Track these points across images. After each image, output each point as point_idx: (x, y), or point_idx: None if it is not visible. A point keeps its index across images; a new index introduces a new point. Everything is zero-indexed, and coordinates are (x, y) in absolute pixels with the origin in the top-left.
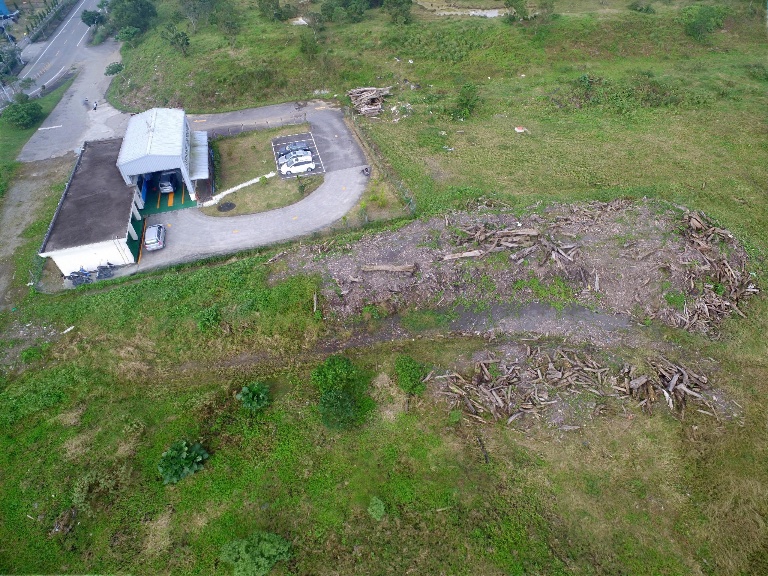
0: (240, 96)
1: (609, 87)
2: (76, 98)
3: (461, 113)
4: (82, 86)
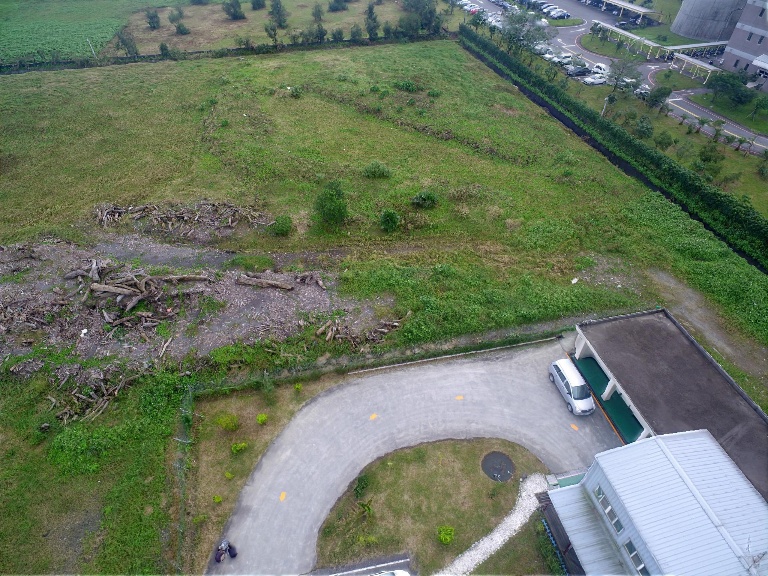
0: None
1: None
2: None
3: None
4: None
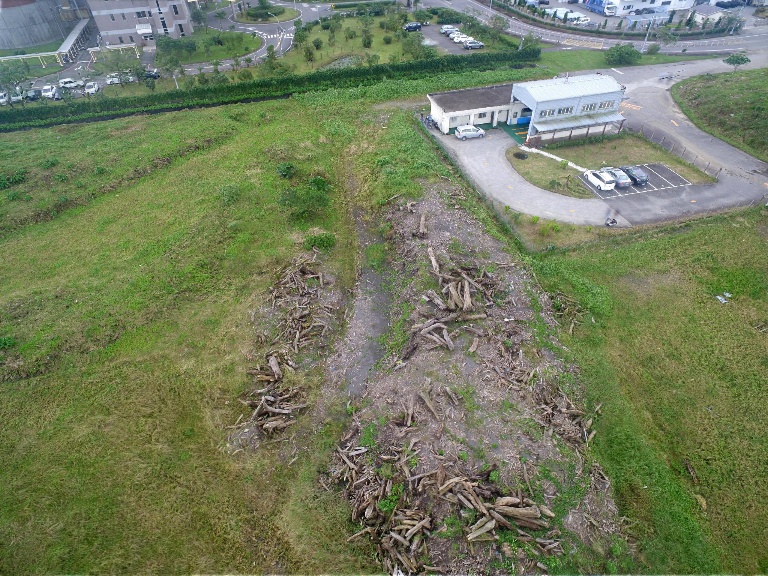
0: (743, 129)
1: None
2: (679, 67)
3: None
4: (707, 63)
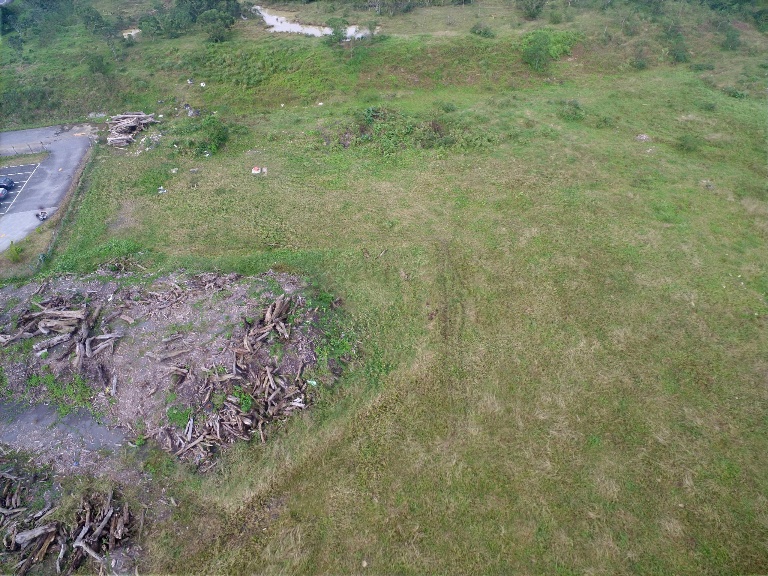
0: (5, 117)
1: (390, 123)
2: None
3: (207, 148)
4: None
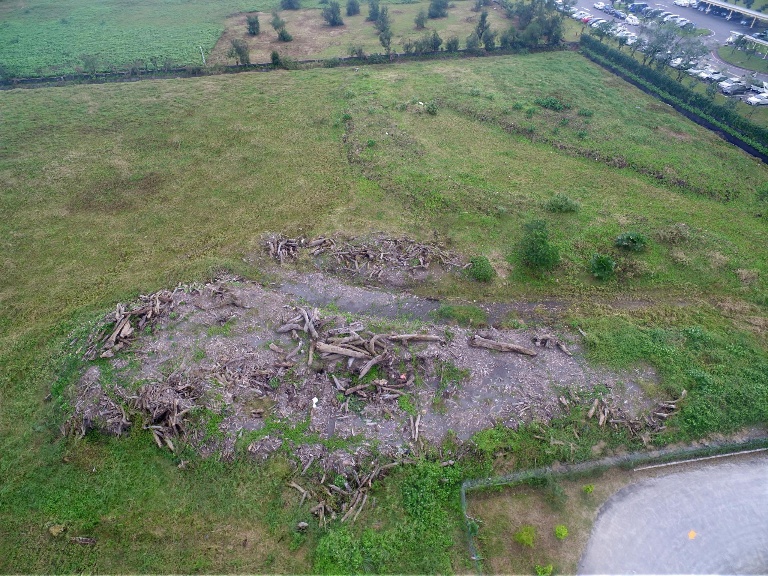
0: None
1: None
2: None
3: None
4: None
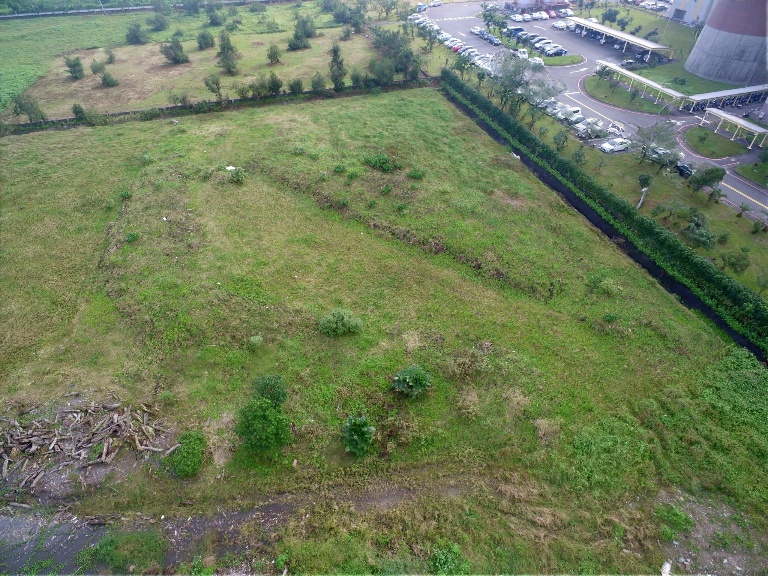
0: None
1: None
2: None
3: None
4: None
